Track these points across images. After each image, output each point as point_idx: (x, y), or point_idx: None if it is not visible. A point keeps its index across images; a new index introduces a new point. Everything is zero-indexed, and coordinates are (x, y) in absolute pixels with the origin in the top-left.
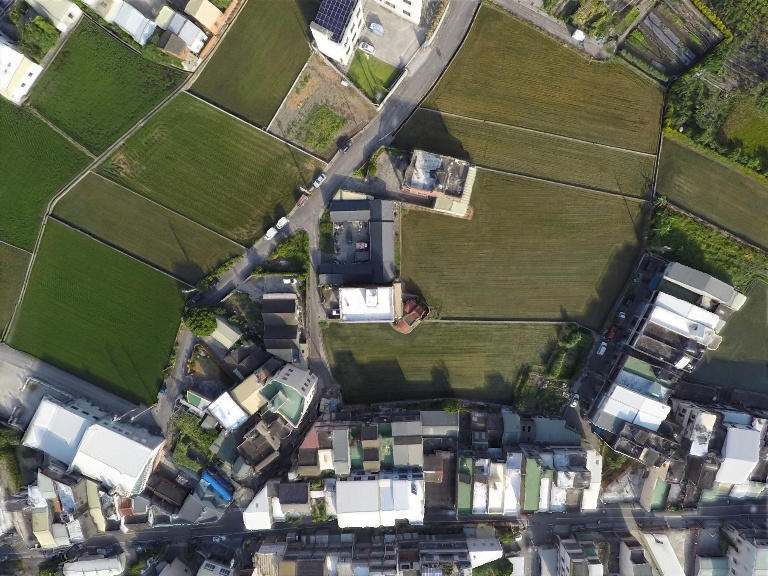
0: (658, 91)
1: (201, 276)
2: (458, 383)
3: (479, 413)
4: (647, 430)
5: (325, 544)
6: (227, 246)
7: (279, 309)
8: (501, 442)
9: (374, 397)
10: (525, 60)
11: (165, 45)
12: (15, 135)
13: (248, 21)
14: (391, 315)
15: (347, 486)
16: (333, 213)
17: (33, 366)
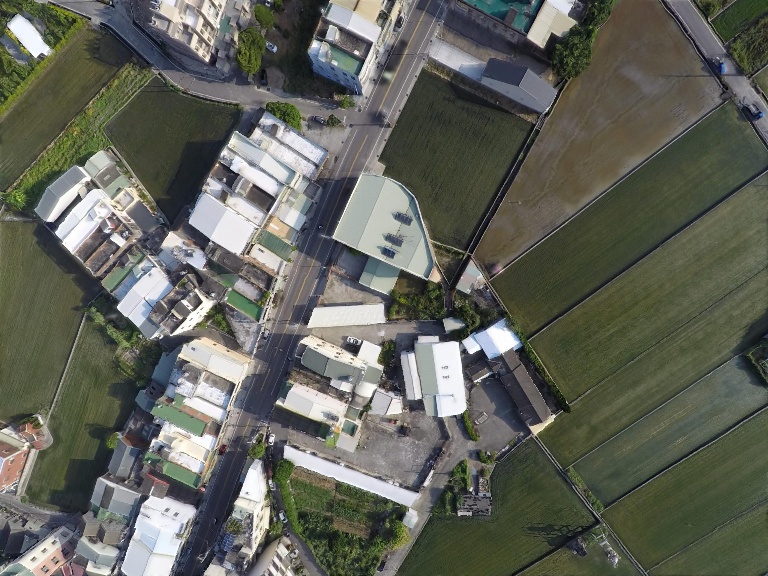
0: None
1: None
2: (110, 421)
3: (131, 421)
4: (164, 298)
5: None
6: None
7: None
8: None
9: None
10: None
11: None
12: None
13: None
14: None
15: (126, 564)
16: None
17: None
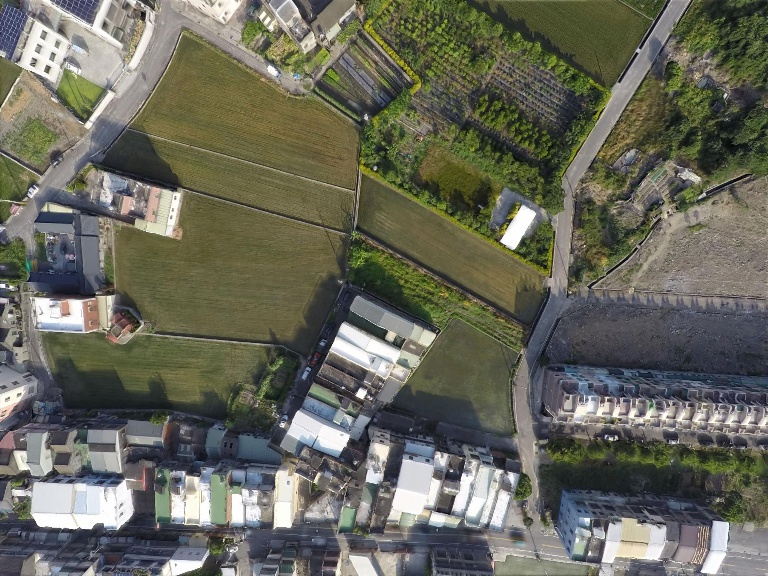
0: (354, 129)
1: None
2: (174, 396)
3: (187, 426)
4: (325, 455)
5: (42, 541)
6: None
7: None
8: None
9: (95, 403)
10: (226, 90)
11: None
12: None
13: None
14: (82, 326)
15: (43, 487)
16: (37, 224)
17: None
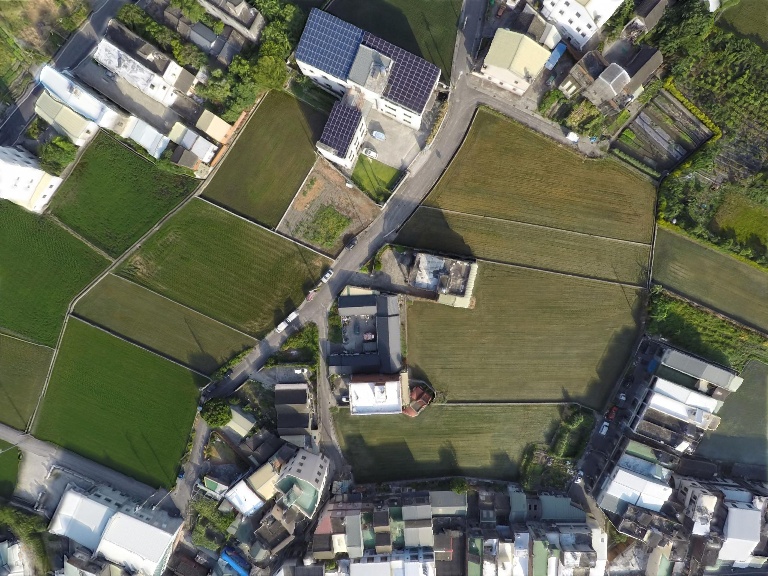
0: (651, 185)
1: (216, 367)
2: (465, 462)
3: (486, 492)
4: (650, 511)
5: None
6: (240, 339)
7: (291, 400)
8: (508, 519)
9: (384, 476)
10: (522, 159)
11: (178, 160)
12: (37, 241)
13: (256, 130)
14: (399, 407)
15: (360, 568)
16: (341, 309)
17: (57, 454)
